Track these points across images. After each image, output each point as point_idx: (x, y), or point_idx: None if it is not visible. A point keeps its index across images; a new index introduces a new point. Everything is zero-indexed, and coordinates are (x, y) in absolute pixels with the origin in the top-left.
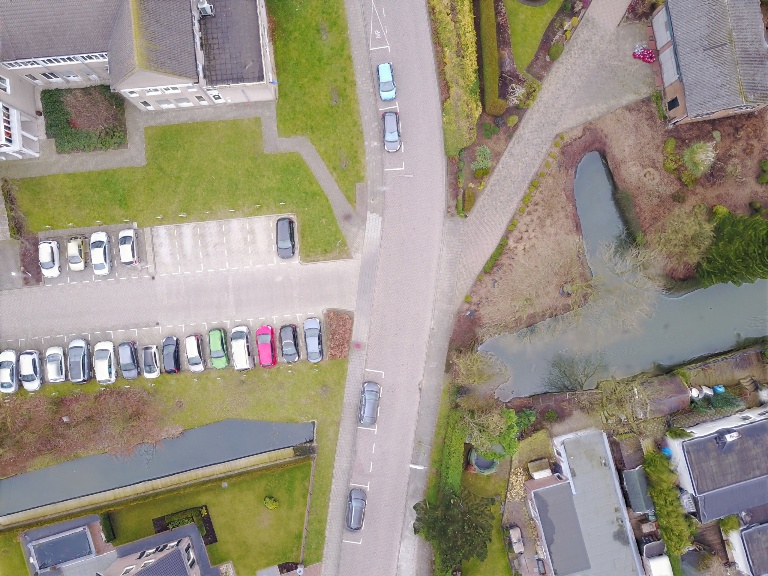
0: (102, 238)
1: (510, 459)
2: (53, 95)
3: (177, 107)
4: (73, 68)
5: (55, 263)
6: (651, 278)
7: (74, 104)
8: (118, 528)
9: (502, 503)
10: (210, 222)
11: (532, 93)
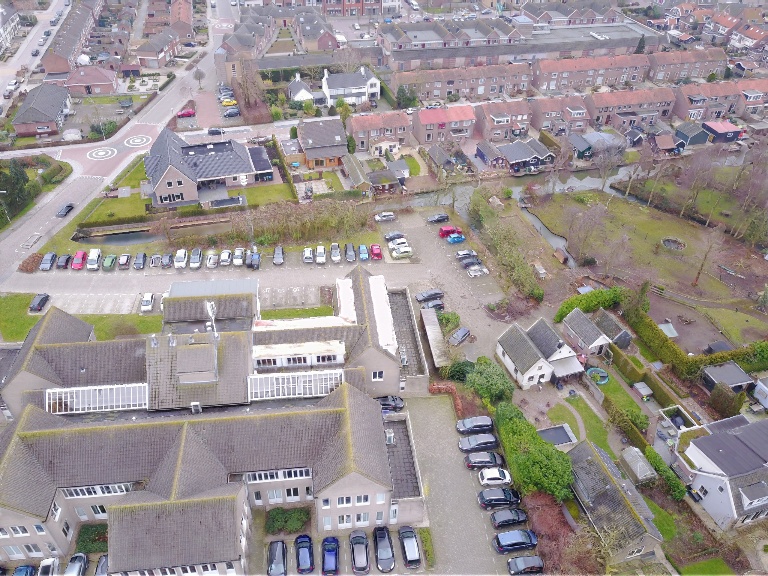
0: None
1: None
2: None
3: None
4: None
5: None
6: None
7: None
8: None
9: None
10: None
11: None
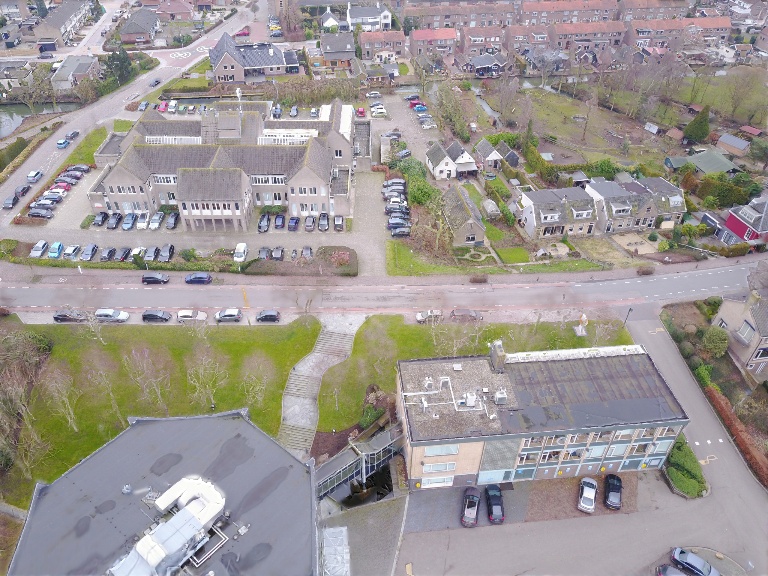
0: None
1: None
2: None
3: None
4: None
5: None
6: (0, 117)
7: None
8: None
9: None
10: None
11: (3, 149)
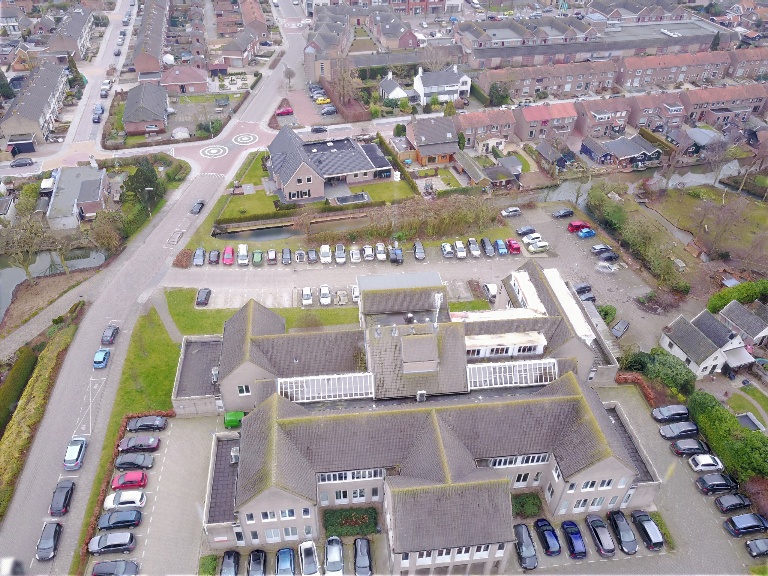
0: (323, 300)
1: None
2: None
3: None
4: None
5: None
6: None
7: None
8: None
9: None
10: None
11: None
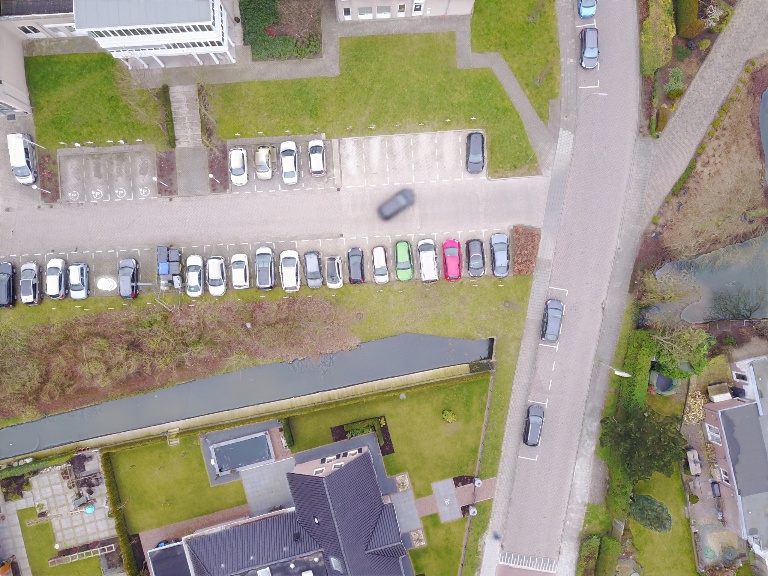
0: (292, 147)
1: (687, 383)
2: (252, 1)
3: (374, 18)
4: None
5: (245, 170)
6: None
7: (273, 11)
8: (297, 435)
9: (678, 426)
10: (398, 135)
11: (725, 17)
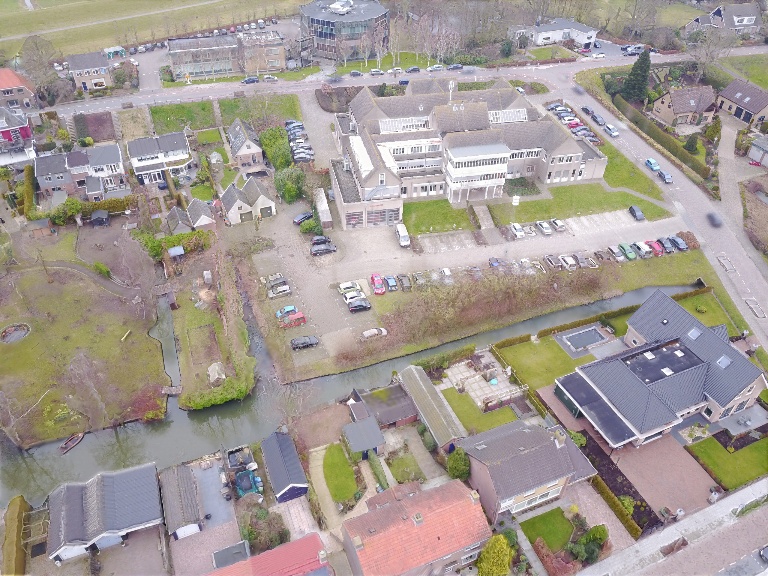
0: None
1: None
2: None
3: (560, 181)
4: (517, 164)
5: None
6: None
7: None
8: None
9: None
10: (593, 215)
11: (716, 172)
